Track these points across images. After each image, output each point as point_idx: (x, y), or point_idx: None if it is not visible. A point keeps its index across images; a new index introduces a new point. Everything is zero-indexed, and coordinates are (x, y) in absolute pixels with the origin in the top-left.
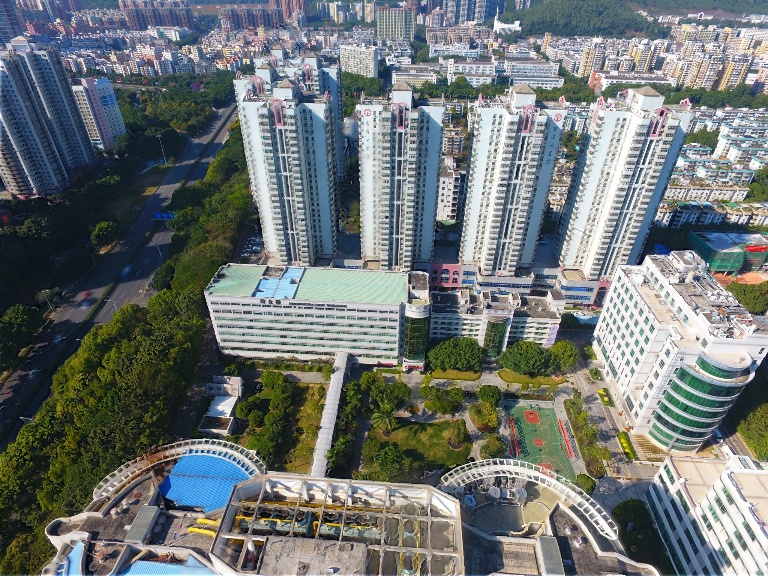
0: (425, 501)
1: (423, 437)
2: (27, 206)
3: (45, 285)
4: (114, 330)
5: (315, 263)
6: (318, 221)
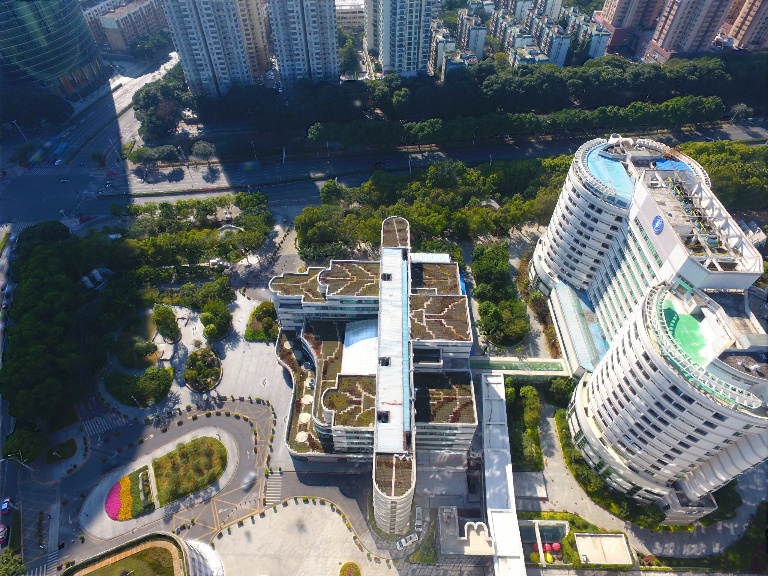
0: (747, 266)
1: None
2: None
3: None
4: (743, 150)
5: None
6: None
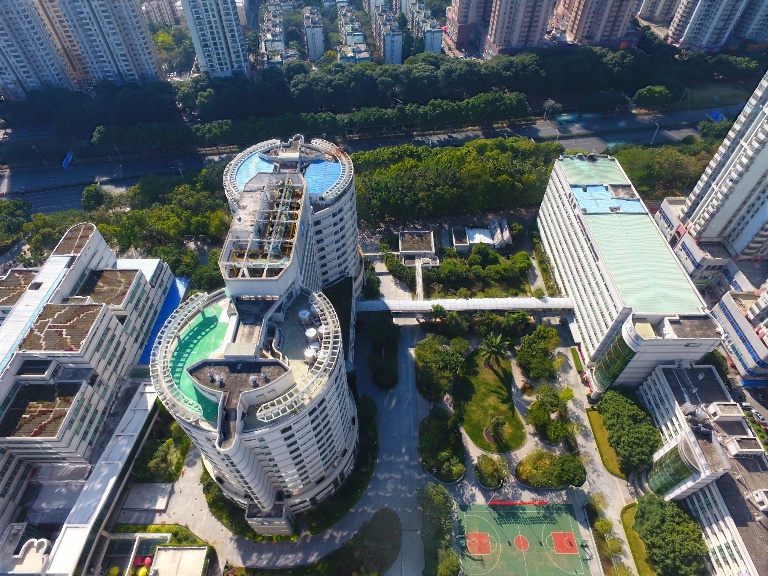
0: None
1: (492, 399)
2: (658, 48)
3: (575, 106)
4: (524, 146)
5: (710, 244)
6: (762, 202)
